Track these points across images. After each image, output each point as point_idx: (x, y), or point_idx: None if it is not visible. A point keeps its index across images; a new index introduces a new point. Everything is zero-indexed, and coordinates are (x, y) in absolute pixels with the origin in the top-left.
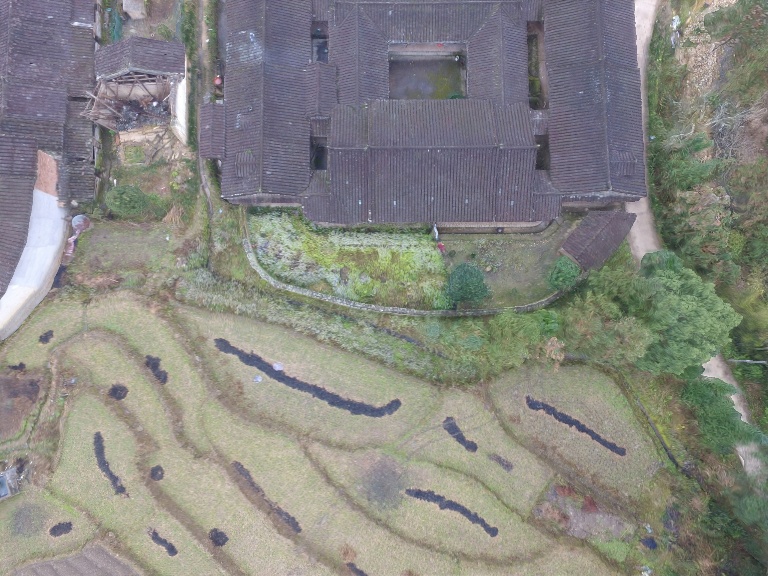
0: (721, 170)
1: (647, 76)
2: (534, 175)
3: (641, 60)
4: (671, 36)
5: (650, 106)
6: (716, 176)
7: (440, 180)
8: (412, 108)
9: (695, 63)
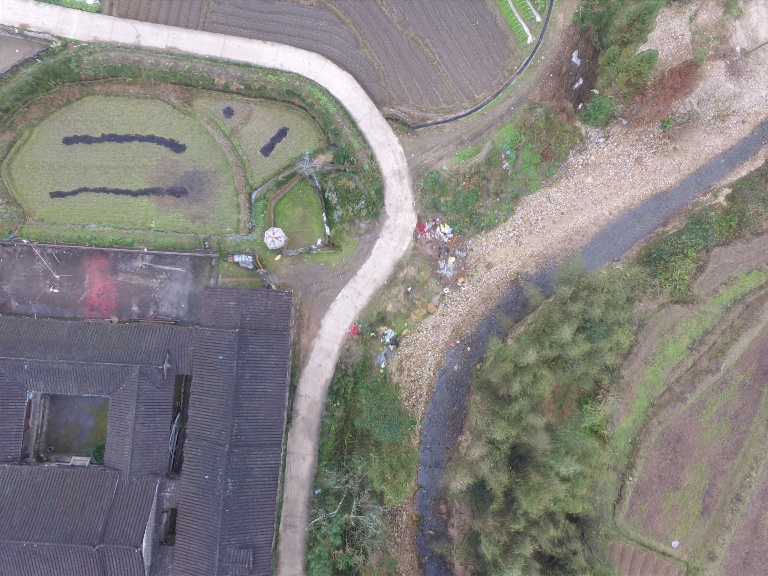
0: (351, 566)
1: (321, 423)
2: (143, 568)
3: (317, 404)
4: (379, 353)
5: (321, 455)
6: (346, 571)
7: (43, 568)
8: (31, 479)
9: (407, 378)
